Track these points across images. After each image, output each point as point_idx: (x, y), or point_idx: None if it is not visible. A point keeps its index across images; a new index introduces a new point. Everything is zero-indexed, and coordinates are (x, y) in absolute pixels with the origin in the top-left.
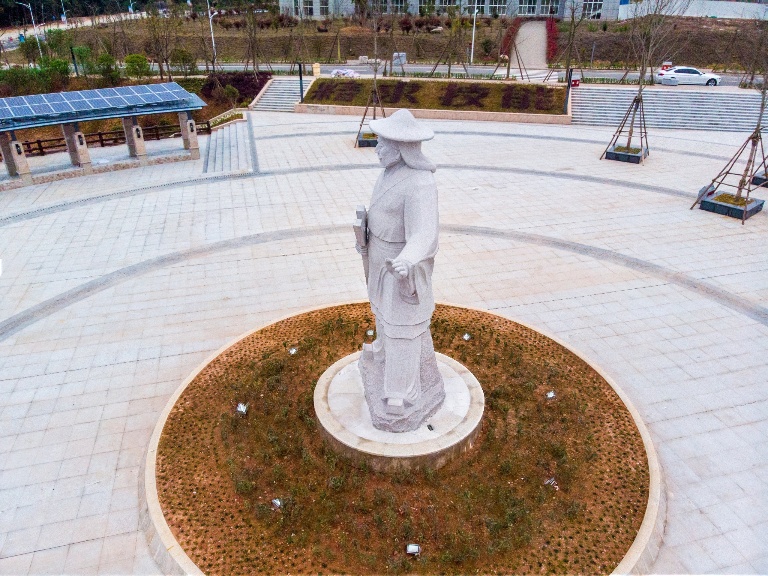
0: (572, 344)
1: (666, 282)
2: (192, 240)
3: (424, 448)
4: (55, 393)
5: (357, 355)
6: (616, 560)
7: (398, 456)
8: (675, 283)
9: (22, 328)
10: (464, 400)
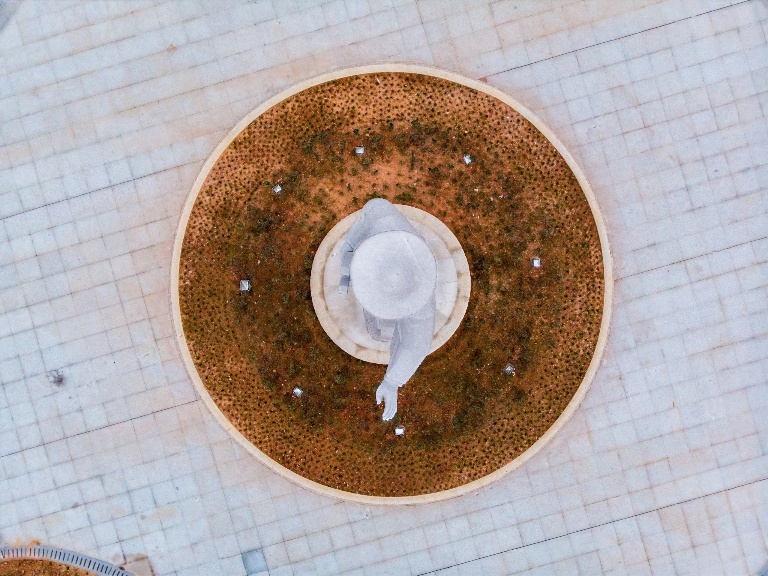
0: (586, 148)
1: None
2: None
3: None
4: (52, 242)
5: (348, 223)
6: (539, 436)
7: None
8: None
9: None
10: (451, 294)
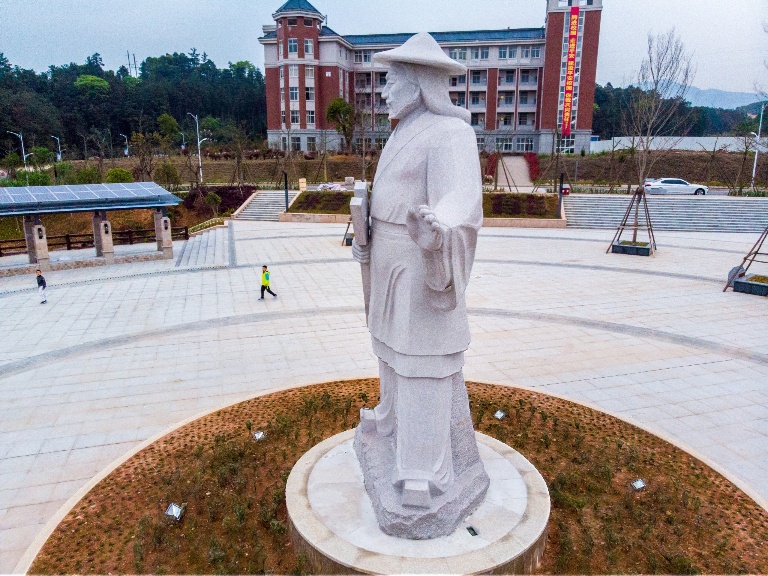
0: None
1: (729, 358)
2: (147, 323)
3: (467, 564)
4: None
5: (351, 433)
6: None
7: None
8: (741, 358)
9: None
10: (517, 489)
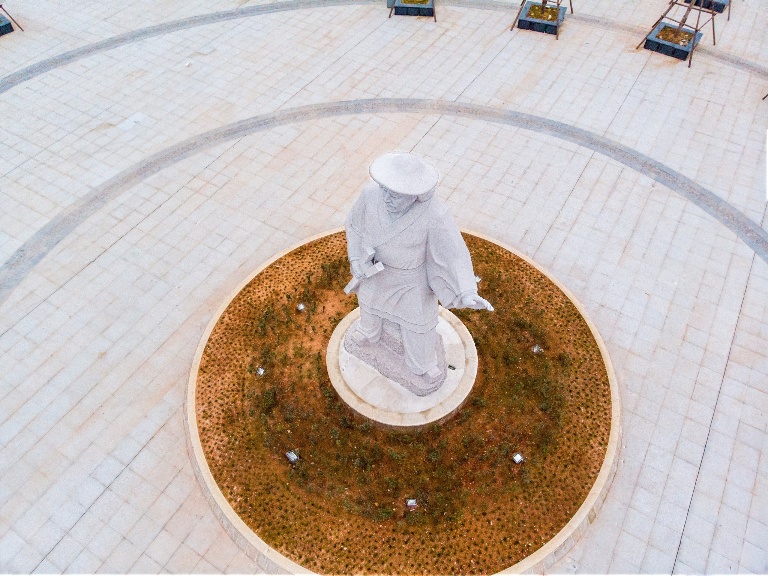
0: None
1: (439, 116)
2: None
3: (466, 387)
4: None
5: (335, 342)
6: (605, 374)
7: None
8: (445, 114)
9: None
10: (448, 328)
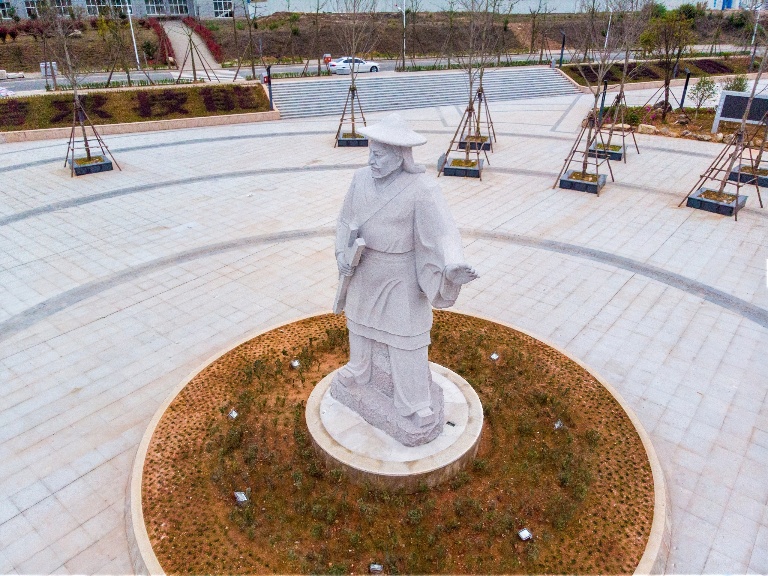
0: None
1: (474, 239)
2: None
3: (465, 444)
4: None
5: (321, 388)
6: (646, 459)
7: (451, 462)
8: (481, 238)
9: None
10: (452, 388)
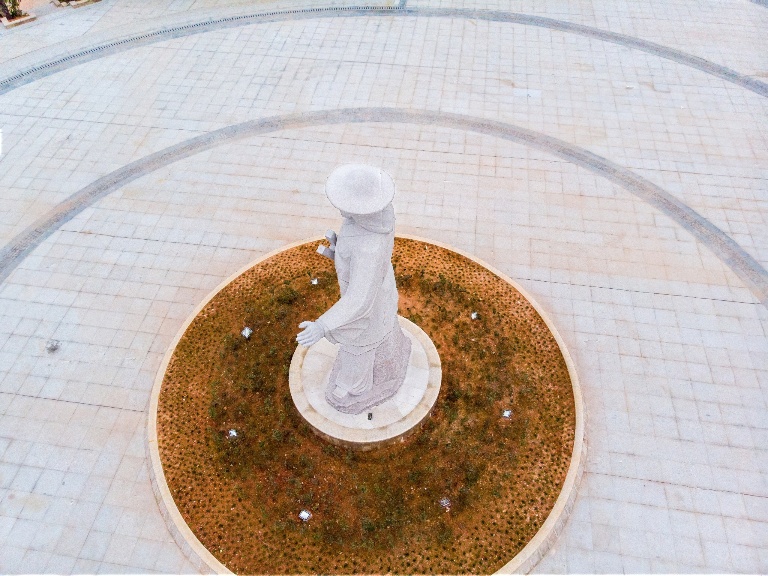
0: (583, 352)
1: (756, 300)
2: (298, 102)
3: (353, 435)
4: (133, 260)
5: None
6: None
7: (329, 435)
8: (766, 305)
9: (131, 180)
10: (415, 398)
